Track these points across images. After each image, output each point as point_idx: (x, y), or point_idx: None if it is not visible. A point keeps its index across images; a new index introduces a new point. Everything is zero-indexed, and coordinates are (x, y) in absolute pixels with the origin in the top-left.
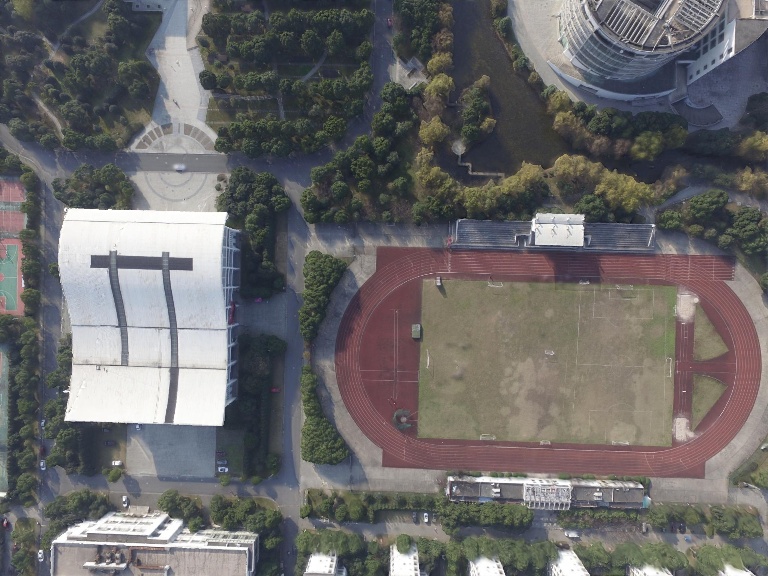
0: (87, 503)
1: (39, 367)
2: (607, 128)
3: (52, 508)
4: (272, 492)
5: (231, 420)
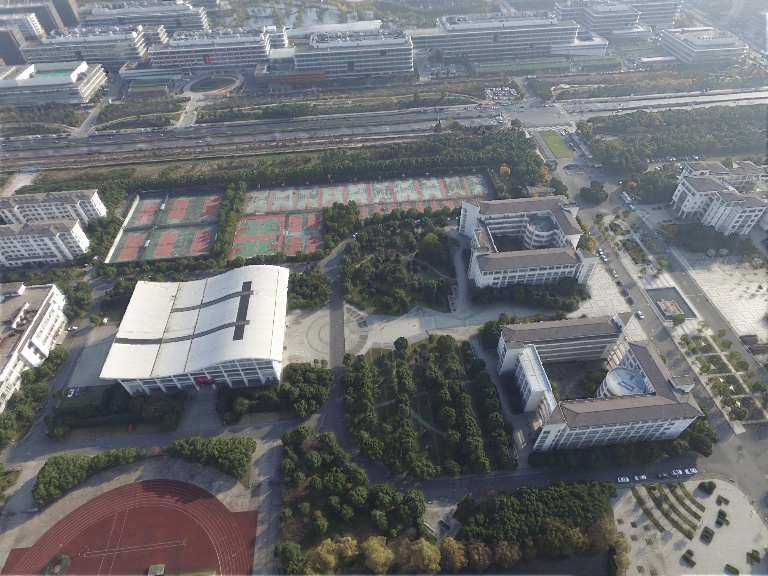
0: (79, 304)
1: (191, 272)
2: None
3: (83, 285)
4: (33, 437)
5: (113, 394)
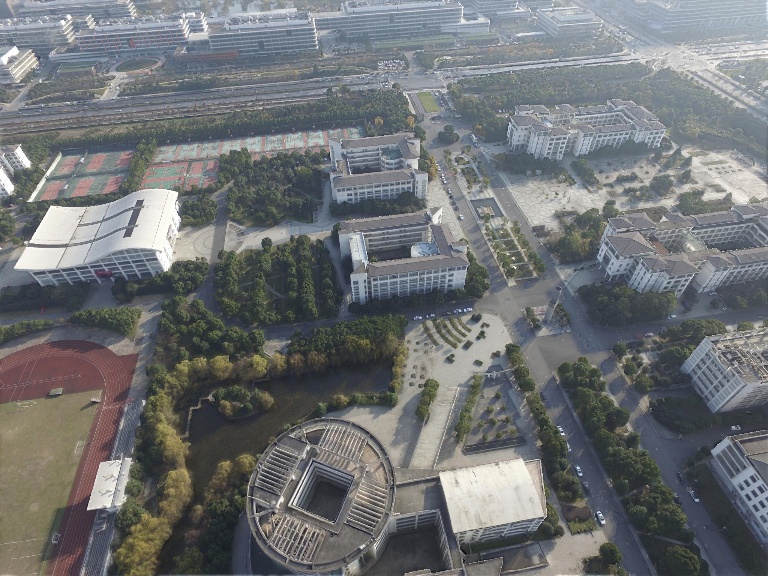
0: (3, 230)
1: None
2: (212, 514)
3: (7, 216)
4: None
5: None
